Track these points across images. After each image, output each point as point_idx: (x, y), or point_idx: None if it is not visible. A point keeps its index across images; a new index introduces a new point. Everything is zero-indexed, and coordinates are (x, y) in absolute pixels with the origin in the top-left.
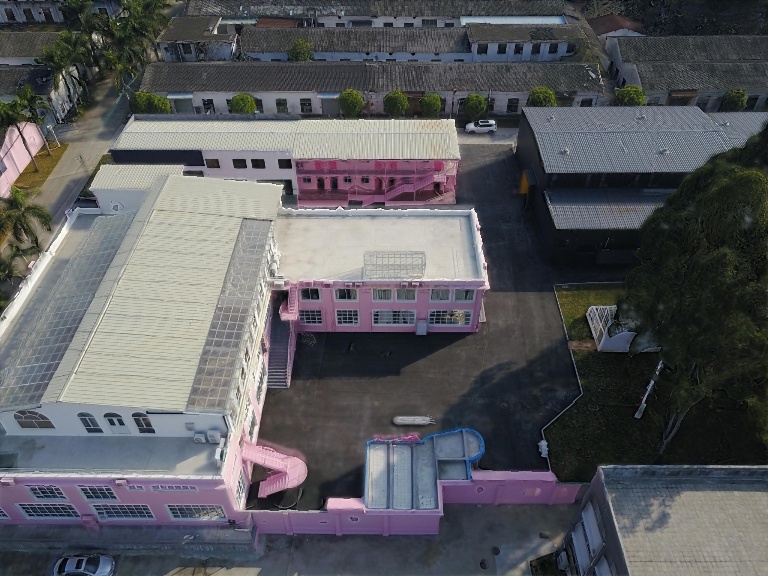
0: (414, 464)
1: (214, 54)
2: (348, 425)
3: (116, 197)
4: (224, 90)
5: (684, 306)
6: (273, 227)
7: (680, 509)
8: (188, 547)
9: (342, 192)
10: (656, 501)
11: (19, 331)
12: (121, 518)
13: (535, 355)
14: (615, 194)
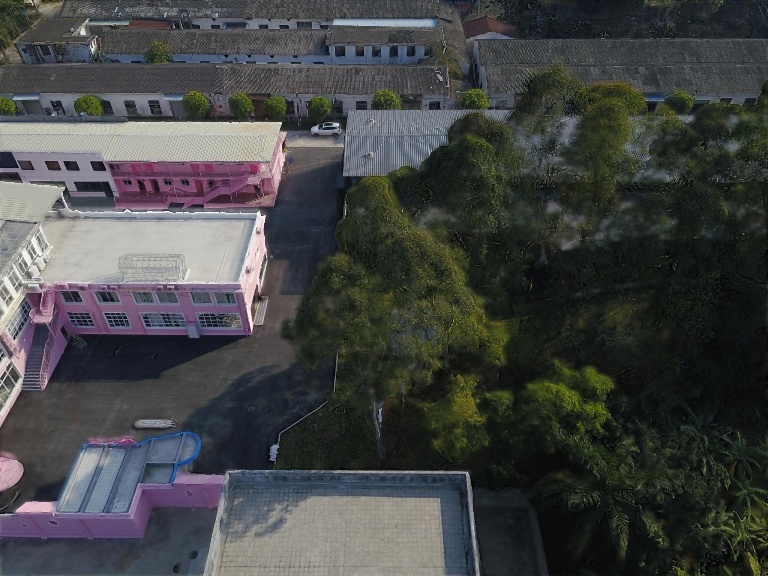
0: (122, 467)
1: (72, 56)
2: (89, 428)
3: None
4: (70, 92)
5: None
6: (35, 229)
7: (299, 514)
8: None
9: (163, 194)
10: (280, 506)
11: None
12: None
13: None
14: None
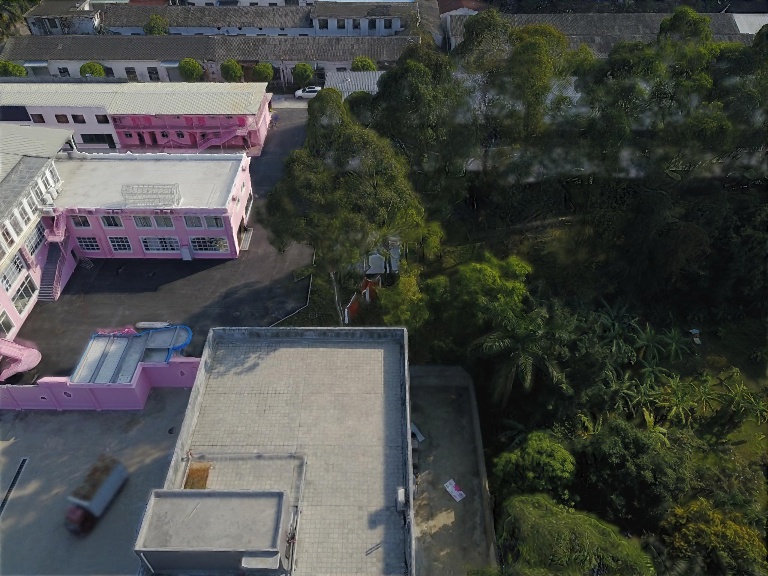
0: (125, 351)
1: (77, 28)
2: (96, 328)
3: None
4: (76, 59)
5: None
6: (49, 163)
7: (269, 360)
8: None
9: (161, 146)
10: (253, 355)
11: None
12: None
13: (280, 276)
14: None
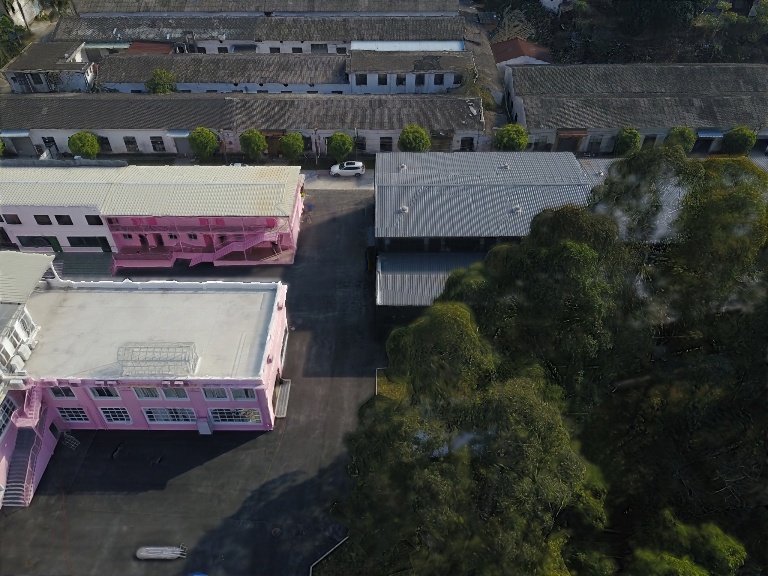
0: None
1: (65, 85)
2: (81, 559)
3: None
4: (63, 127)
5: (355, 488)
6: (18, 312)
7: None
8: None
9: (168, 249)
10: None
11: None
12: None
13: (331, 462)
14: (458, 260)
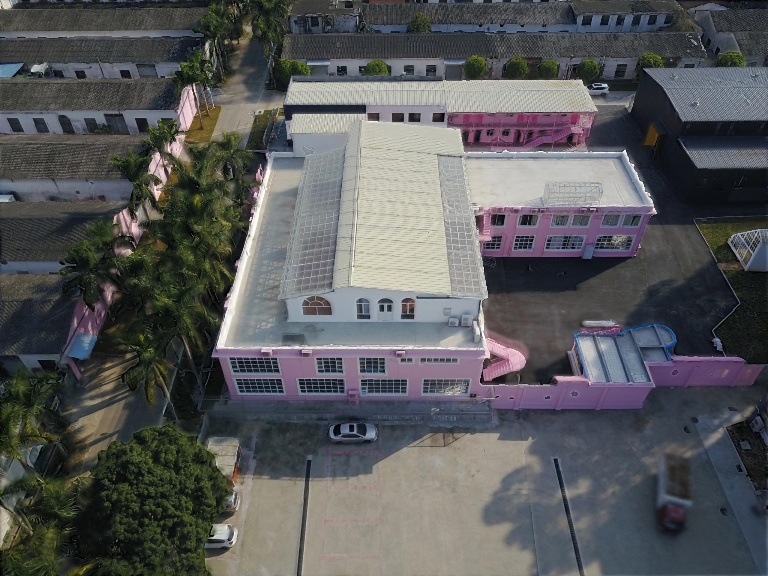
0: (620, 350)
1: (340, 26)
2: (543, 328)
3: (310, 141)
4: (358, 57)
5: None
6: (464, 162)
7: None
8: (435, 418)
9: (484, 144)
10: None
11: (263, 247)
12: (378, 394)
13: (691, 274)
14: (742, 141)
